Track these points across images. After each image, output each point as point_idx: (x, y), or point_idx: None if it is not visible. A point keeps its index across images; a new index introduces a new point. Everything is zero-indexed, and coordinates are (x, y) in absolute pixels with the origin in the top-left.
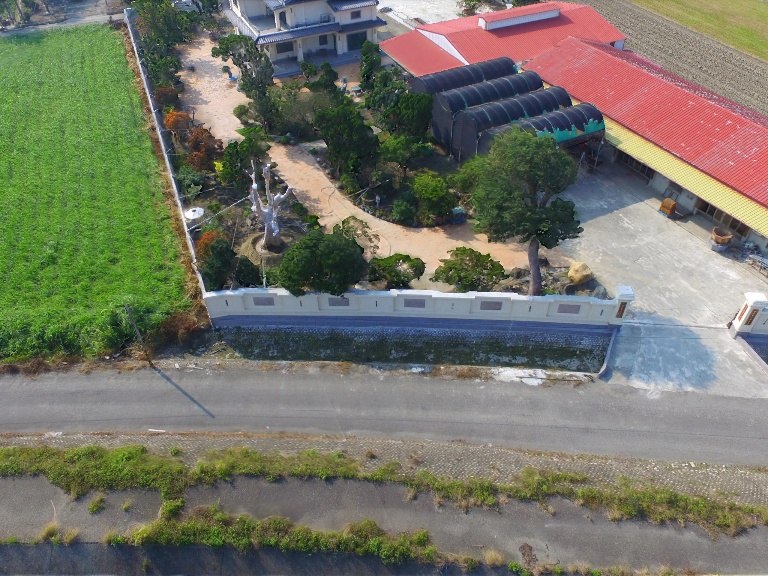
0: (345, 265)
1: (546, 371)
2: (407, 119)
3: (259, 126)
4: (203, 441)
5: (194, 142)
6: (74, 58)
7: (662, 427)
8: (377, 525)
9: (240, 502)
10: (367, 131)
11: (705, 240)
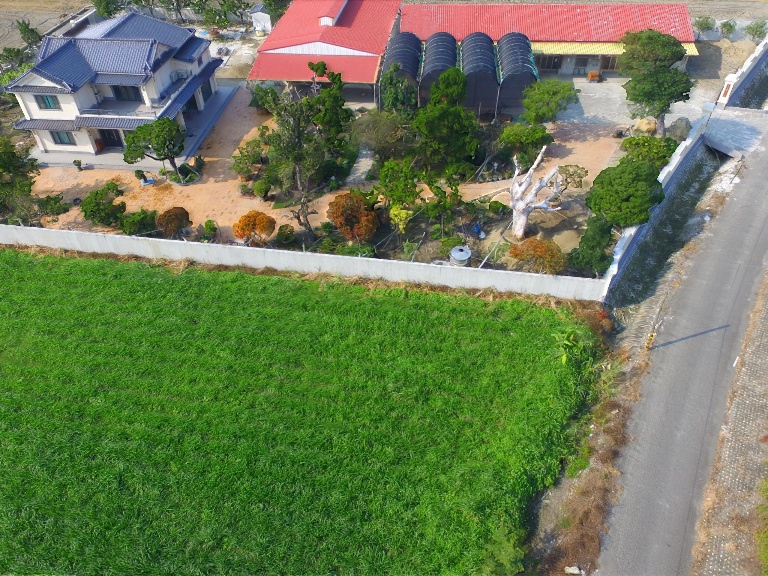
0: None
1: None
2: (457, 95)
3: (285, 192)
4: (765, 332)
5: (345, 213)
6: None
7: None
8: None
9: None
10: None
11: None
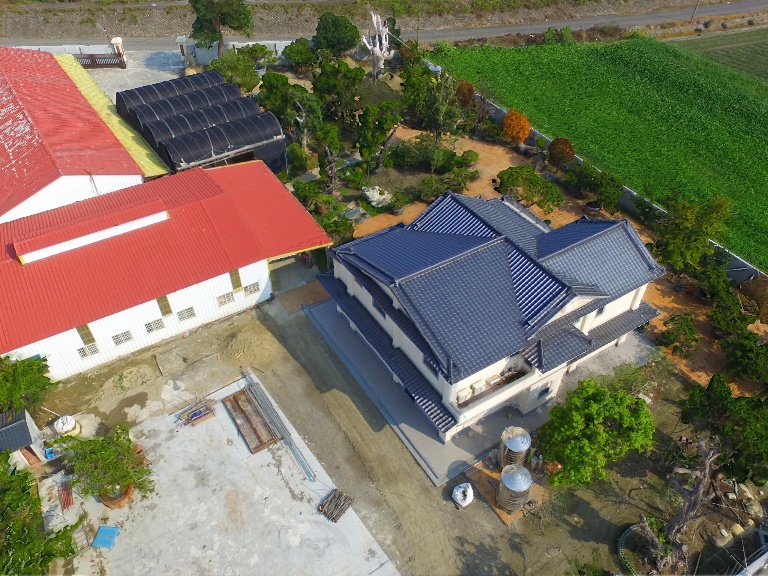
0: None
1: None
2: None
3: None
4: None
5: None
6: None
7: (189, 42)
8: None
9: None
10: None
11: None
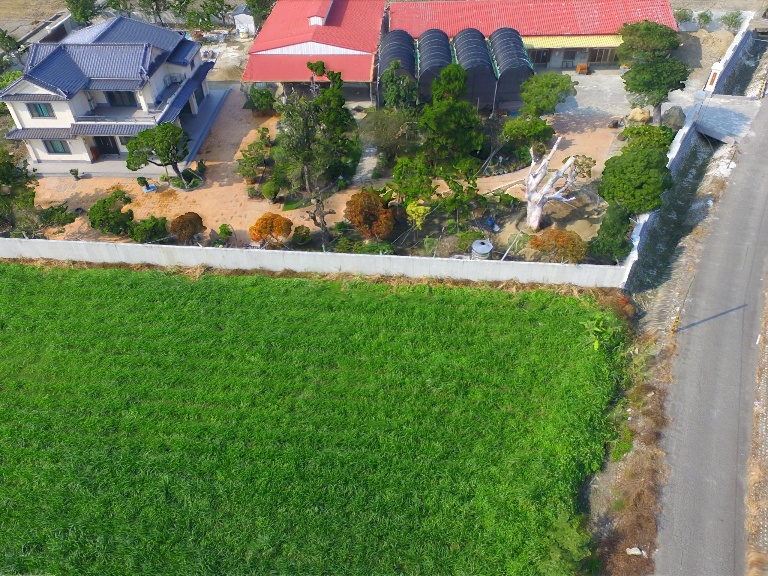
0: None
1: None
2: (459, 90)
3: (293, 194)
4: None
5: (363, 212)
6: None
7: None
8: None
9: None
10: None
11: (617, 74)
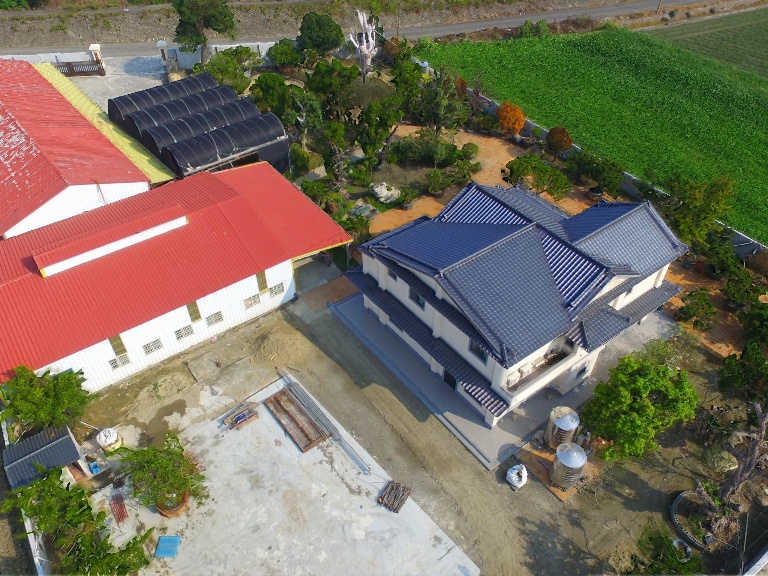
0: None
1: None
2: None
3: None
4: None
5: None
6: None
7: None
8: (280, 1)
9: (326, 0)
10: None
11: None
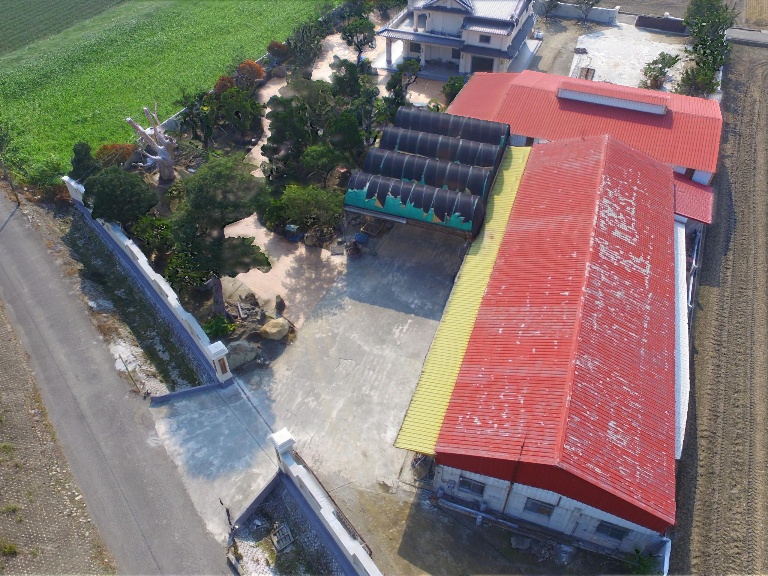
0: (104, 199)
1: (144, 369)
2: None
3: None
4: None
5: None
6: (303, 4)
7: (115, 462)
8: None
9: None
10: (292, 128)
11: None
